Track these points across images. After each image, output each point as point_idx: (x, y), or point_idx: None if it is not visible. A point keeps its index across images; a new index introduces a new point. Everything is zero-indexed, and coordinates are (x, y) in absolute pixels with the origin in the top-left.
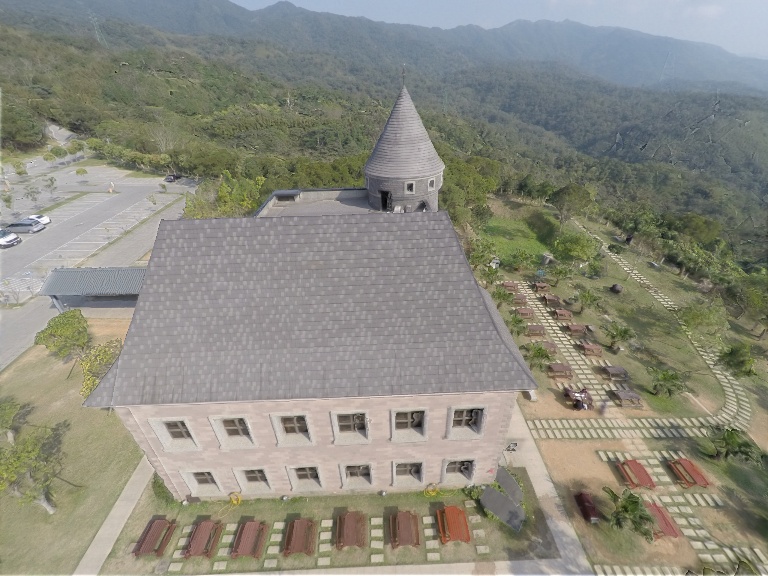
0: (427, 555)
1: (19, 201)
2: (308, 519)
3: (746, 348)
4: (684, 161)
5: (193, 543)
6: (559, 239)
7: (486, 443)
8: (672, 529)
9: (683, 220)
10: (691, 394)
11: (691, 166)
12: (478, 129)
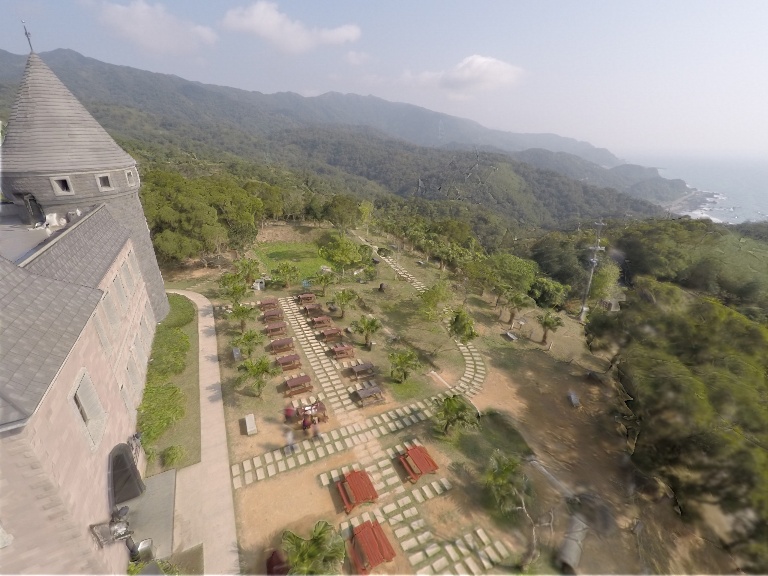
0: None
1: None
2: None
3: None
4: (468, 198)
5: None
6: None
7: (36, 547)
8: (387, 550)
9: (443, 225)
10: (435, 372)
11: (473, 201)
12: (303, 179)
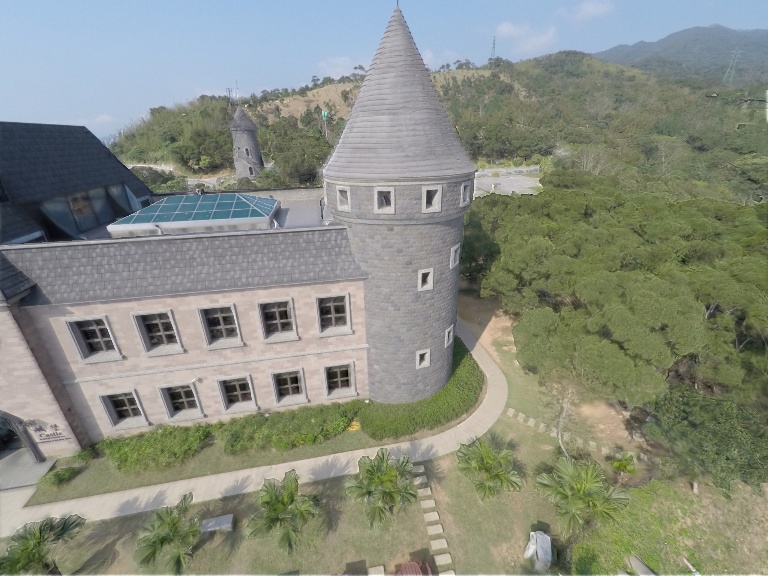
0: None
1: None
2: None
3: None
4: None
5: None
6: None
7: None
8: None
9: None
10: None
11: None
12: None
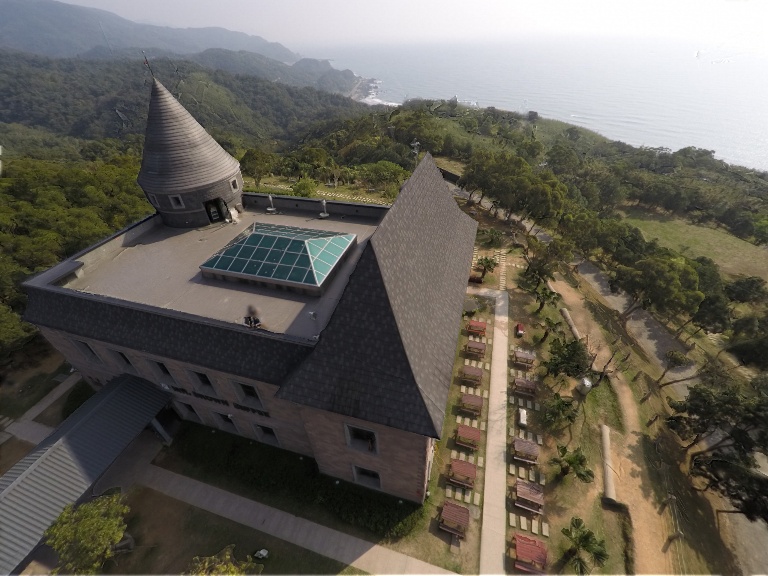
0: (489, 344)
1: None
2: (458, 400)
3: None
4: None
5: (468, 476)
6: None
7: None
8: None
9: (307, 154)
10: None
11: None
12: None
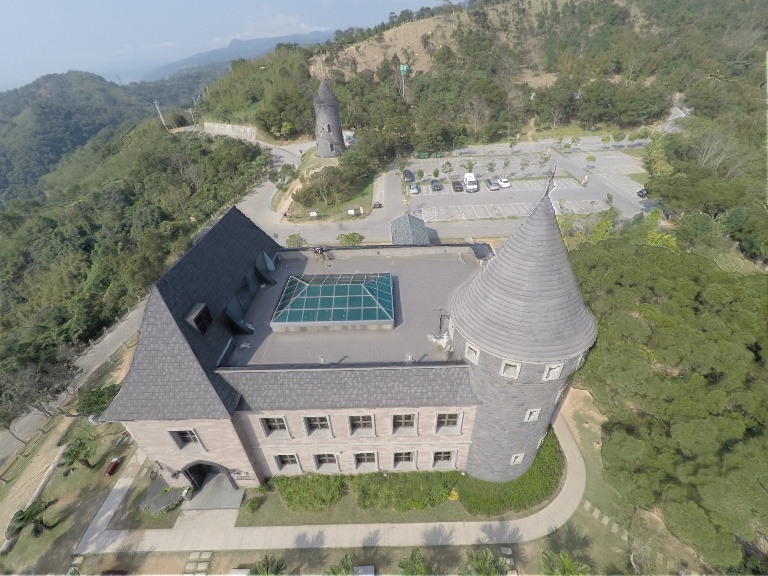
0: None
1: (532, 166)
2: None
3: None
4: None
5: None
6: None
7: None
8: None
9: None
10: None
11: None
12: None
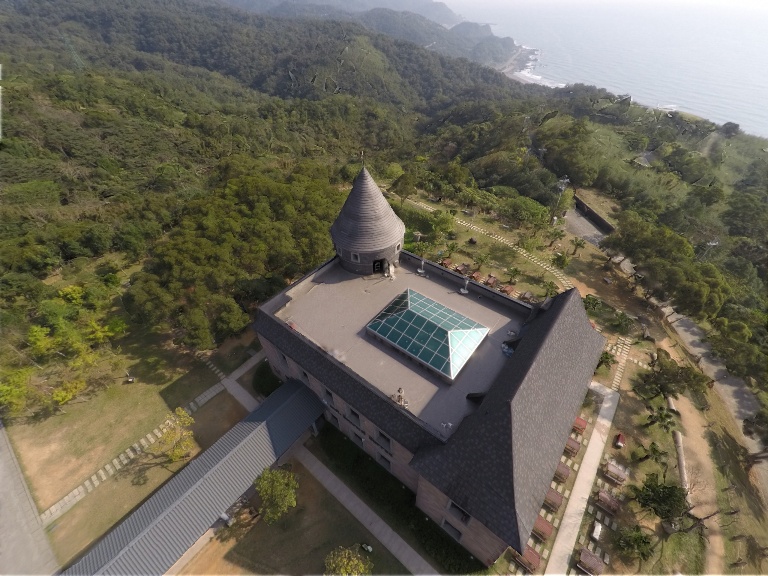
0: (584, 444)
1: None
2: None
3: (565, 254)
4: (346, 90)
5: (532, 563)
6: (431, 223)
7: None
8: None
9: (451, 172)
10: None
11: (353, 93)
12: (151, 88)
